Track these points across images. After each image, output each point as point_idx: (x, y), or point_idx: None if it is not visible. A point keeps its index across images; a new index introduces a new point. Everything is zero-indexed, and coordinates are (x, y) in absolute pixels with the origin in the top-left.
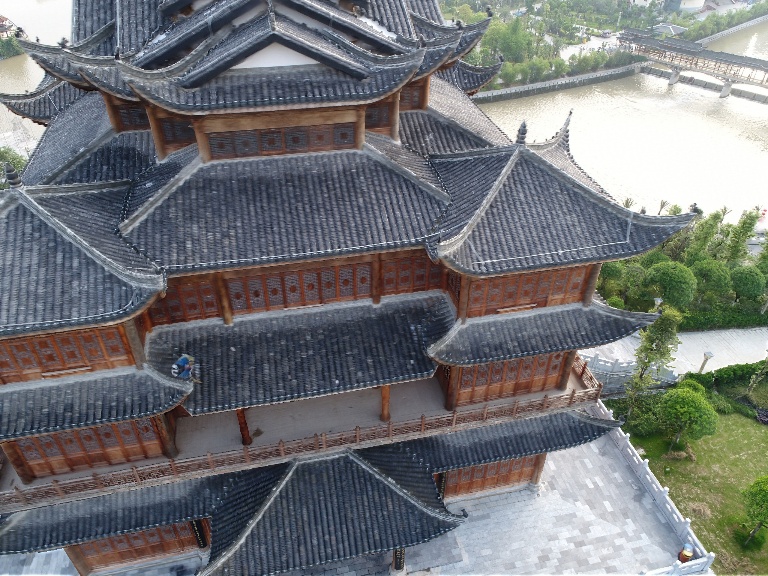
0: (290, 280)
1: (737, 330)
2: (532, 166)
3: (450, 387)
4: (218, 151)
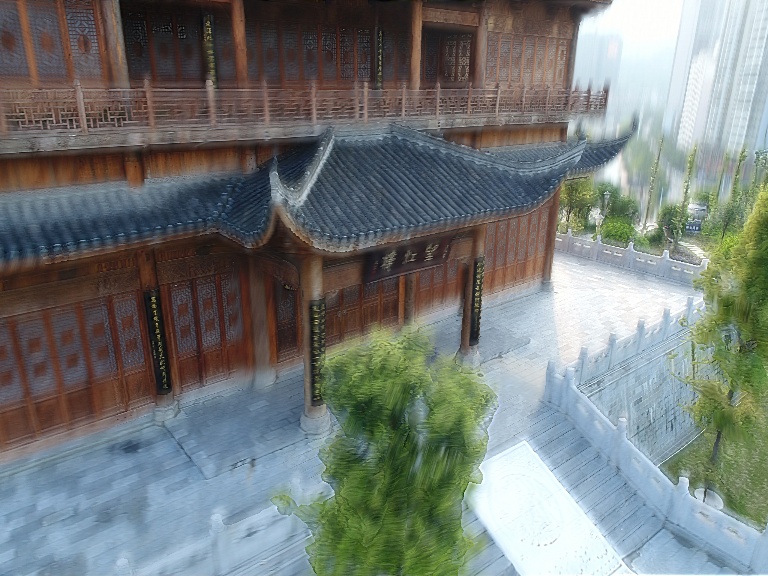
0: None
1: (592, 234)
2: None
3: (478, 71)
4: None
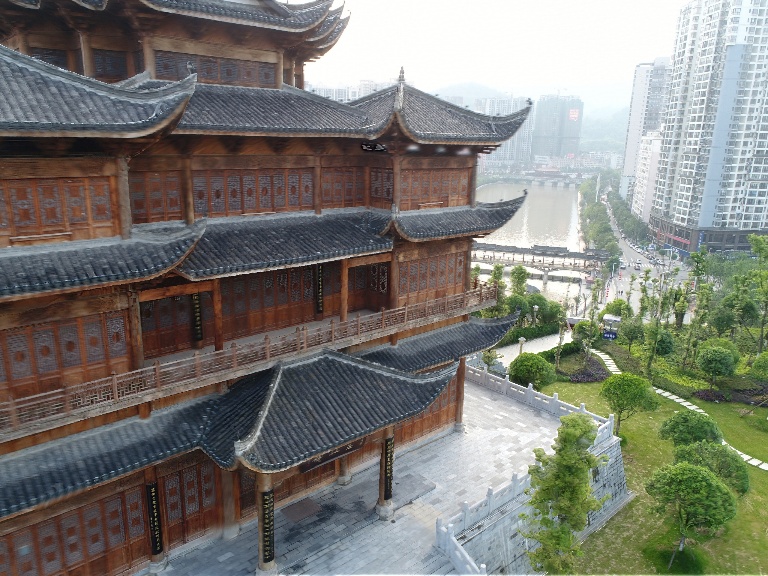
0: (248, 181)
1: None
2: (414, 96)
3: (392, 290)
4: (162, 71)
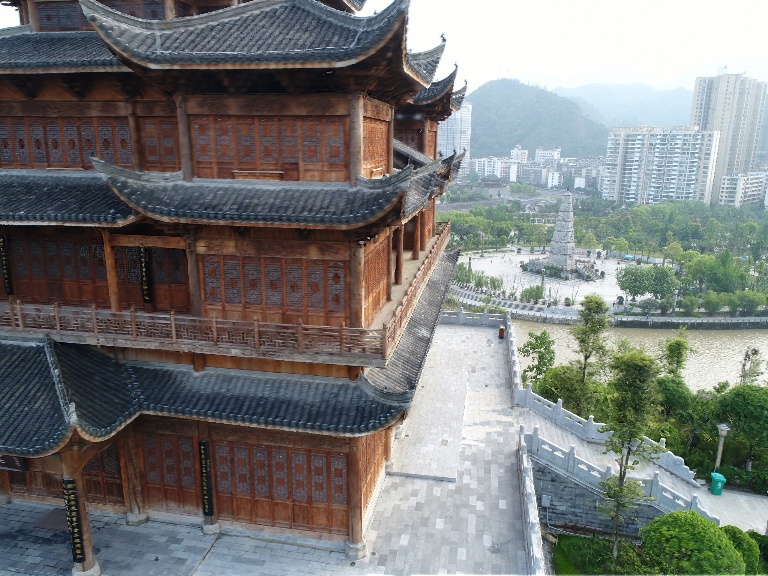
0: (52, 131)
1: None
2: (297, 8)
3: None
4: (46, 23)
